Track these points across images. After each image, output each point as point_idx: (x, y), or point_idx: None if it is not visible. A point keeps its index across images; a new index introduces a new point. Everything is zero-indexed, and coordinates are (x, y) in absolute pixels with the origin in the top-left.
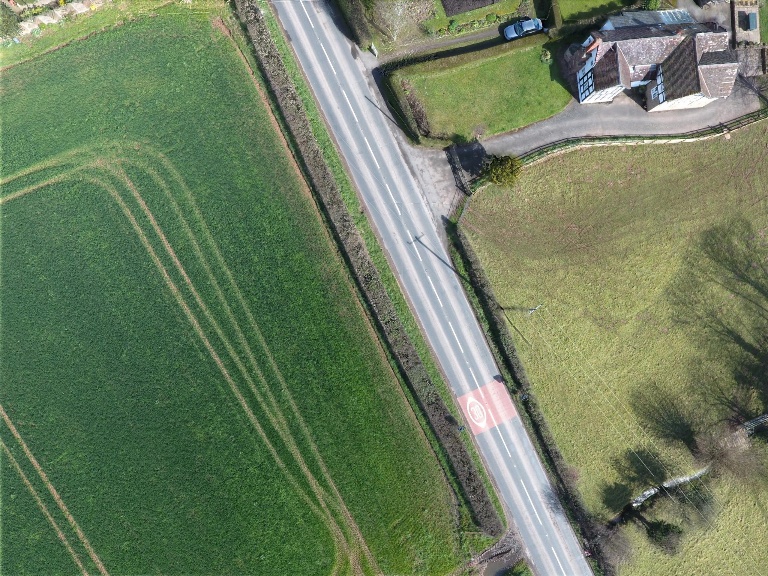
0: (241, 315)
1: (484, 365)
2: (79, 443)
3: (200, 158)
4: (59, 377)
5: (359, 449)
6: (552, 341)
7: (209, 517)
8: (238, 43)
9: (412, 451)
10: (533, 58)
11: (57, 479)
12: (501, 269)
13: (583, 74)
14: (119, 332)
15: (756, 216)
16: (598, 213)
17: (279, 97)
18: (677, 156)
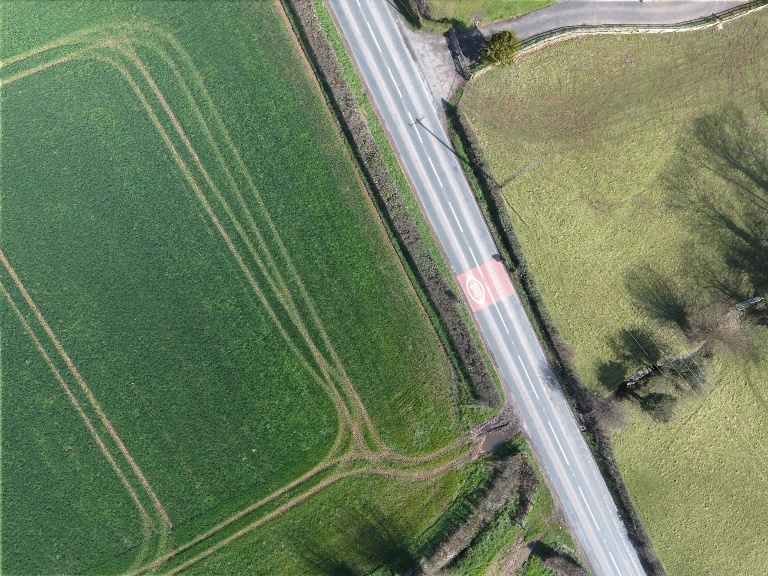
0: (248, 191)
1: (483, 244)
2: (92, 312)
3: (208, 39)
4: (72, 248)
5: (362, 323)
6: (549, 222)
7: (217, 386)
8: None
9: (413, 327)
10: None
11: (70, 346)
12: (499, 152)
13: None
14: (130, 206)
15: (747, 105)
16: (594, 99)
17: None
18: (671, 45)
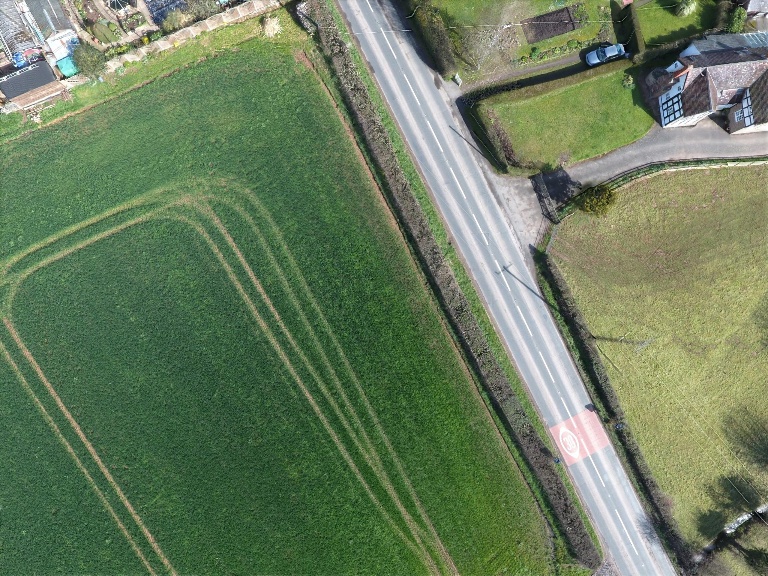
0: (332, 351)
1: (575, 394)
2: (173, 485)
3: (287, 193)
4: (151, 419)
5: (453, 483)
6: (642, 368)
7: (305, 557)
8: (322, 76)
9: (506, 483)
10: (615, 83)
11: (152, 522)
12: (590, 297)
13: (667, 98)
14: (210, 371)
15: None
16: (684, 237)
17: (366, 130)
18: (761, 178)
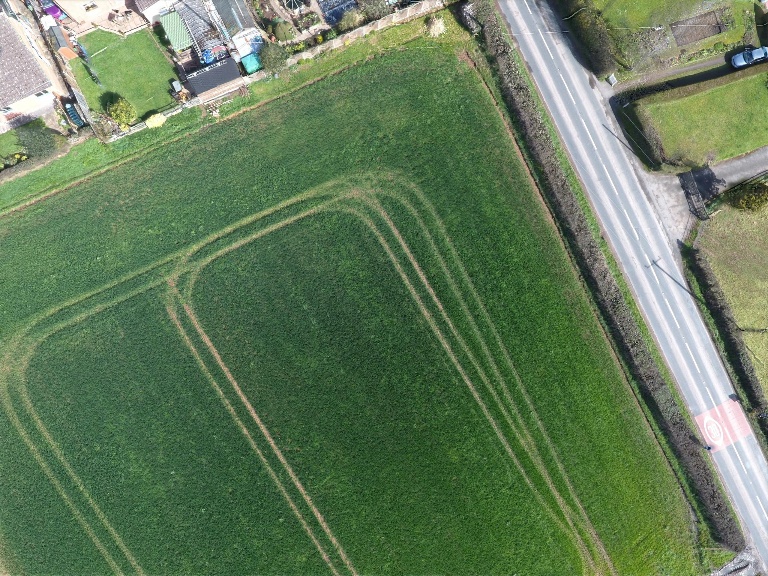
0: (491, 340)
1: (720, 385)
2: (342, 467)
3: (451, 187)
4: (322, 403)
5: (604, 468)
6: None
7: (464, 537)
8: (483, 75)
9: (653, 470)
10: (759, 85)
11: (322, 503)
12: (734, 291)
13: None
14: (378, 358)
15: None
16: None
17: (529, 127)
18: None
